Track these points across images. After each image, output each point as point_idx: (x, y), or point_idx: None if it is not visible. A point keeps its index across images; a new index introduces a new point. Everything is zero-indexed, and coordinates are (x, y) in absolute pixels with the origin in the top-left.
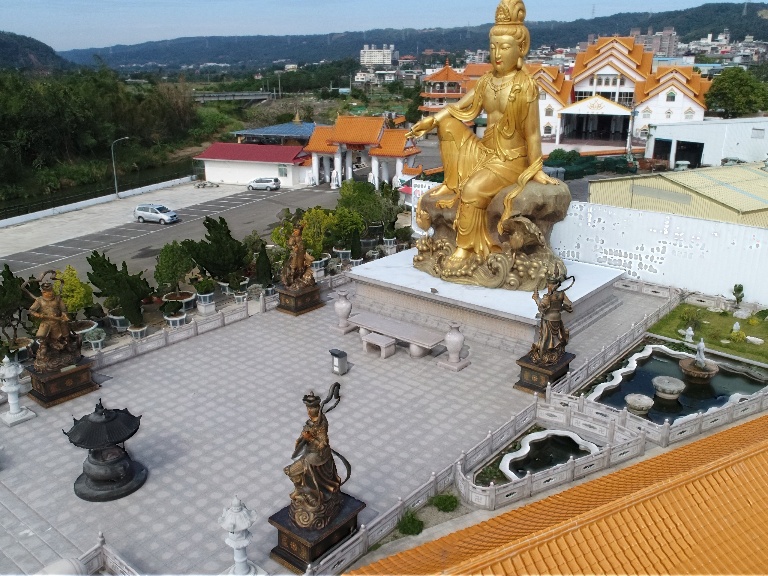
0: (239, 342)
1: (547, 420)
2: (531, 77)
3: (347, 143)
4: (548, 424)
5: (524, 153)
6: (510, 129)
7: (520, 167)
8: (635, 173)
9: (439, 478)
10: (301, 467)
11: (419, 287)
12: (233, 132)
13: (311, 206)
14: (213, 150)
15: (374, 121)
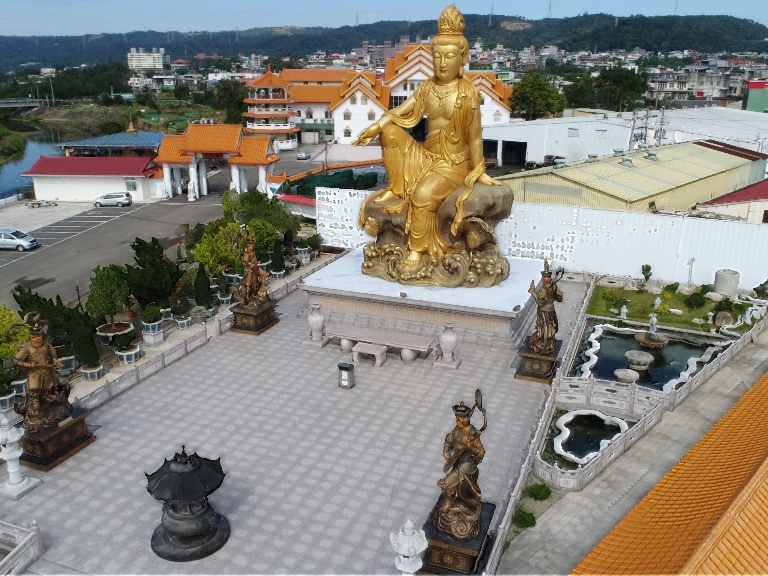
0: (217, 369)
1: (567, 403)
2: (474, 85)
3: (203, 152)
4: (569, 406)
5: (467, 157)
6: (457, 134)
7: (465, 170)
8: None
9: None
10: (456, 478)
11: (385, 293)
12: (60, 144)
13: (181, 220)
14: (42, 165)
15: (230, 129)
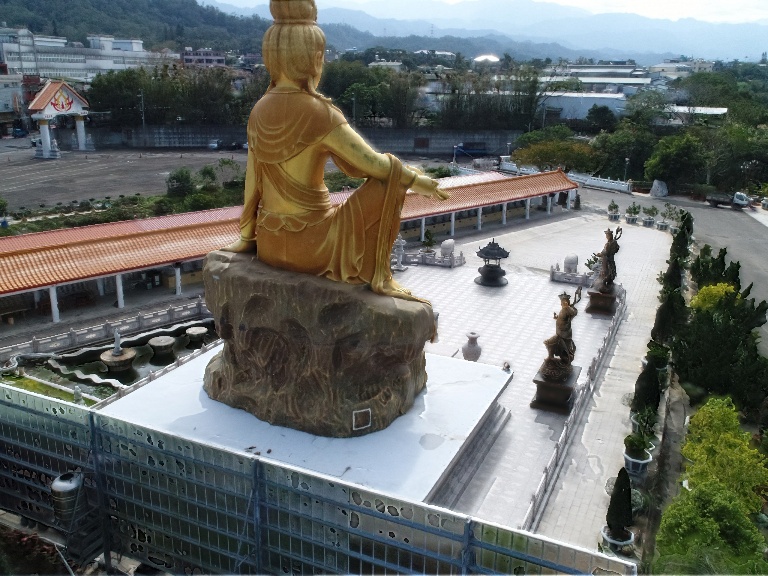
0: None
1: None
2: None
3: None
4: None
5: None
6: None
7: None
8: None
9: None
10: None
11: None
12: None
13: None
14: None
15: None
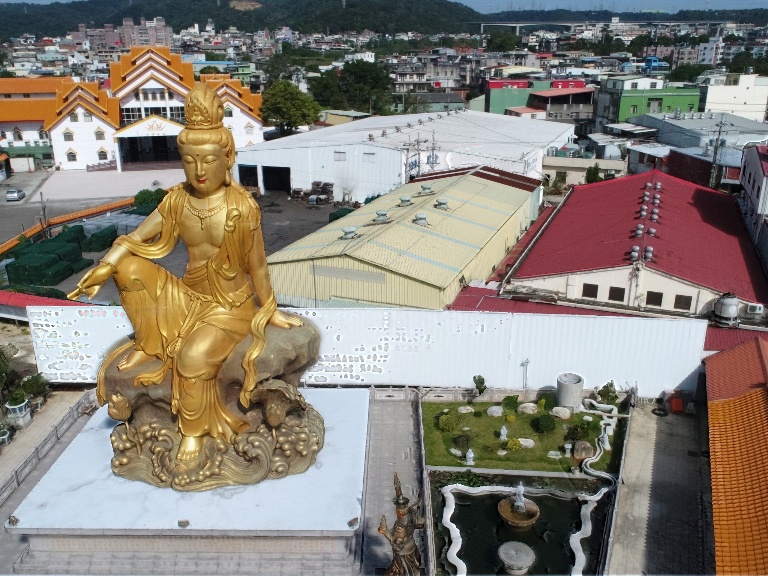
0: None
1: None
2: (249, 196)
3: None
4: None
5: (250, 291)
6: (232, 267)
7: (250, 311)
8: None
9: None
10: None
11: (154, 522)
12: None
13: None
14: None
15: None
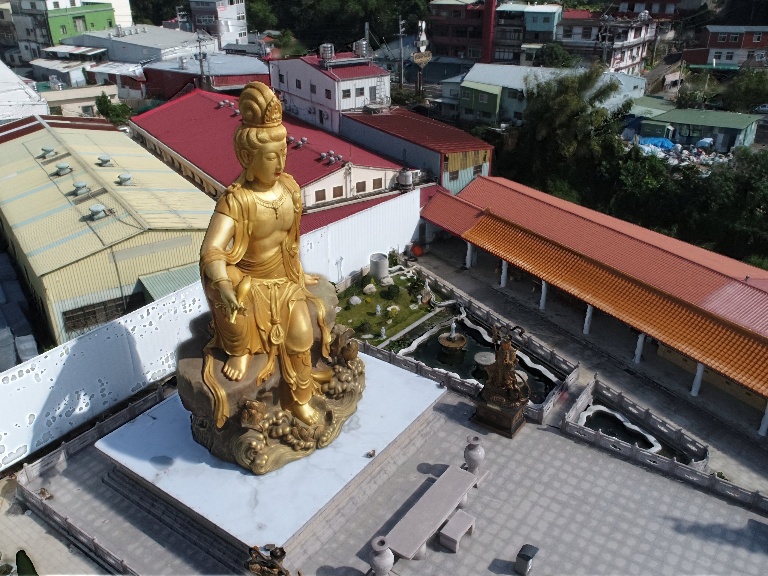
0: None
1: None
2: None
3: None
4: None
5: None
6: None
7: None
8: None
9: (707, 476)
10: None
11: (352, 469)
12: None
13: None
14: None
15: None
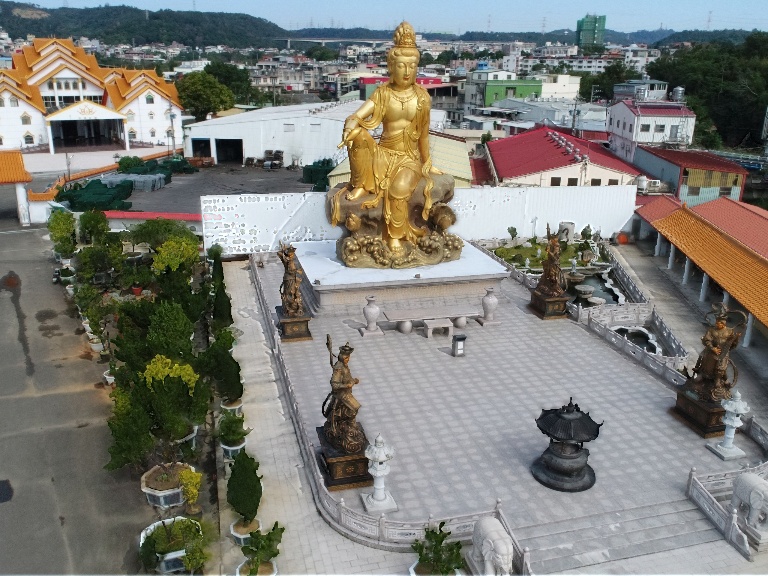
0: None
1: None
2: None
3: None
4: None
5: None
6: (418, 133)
7: None
8: (199, 172)
9: None
10: None
11: (399, 278)
12: None
13: None
14: None
15: None
